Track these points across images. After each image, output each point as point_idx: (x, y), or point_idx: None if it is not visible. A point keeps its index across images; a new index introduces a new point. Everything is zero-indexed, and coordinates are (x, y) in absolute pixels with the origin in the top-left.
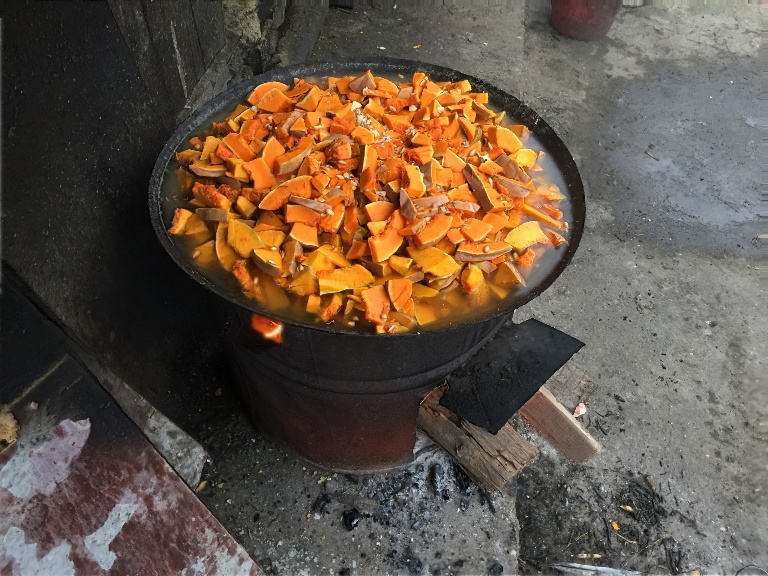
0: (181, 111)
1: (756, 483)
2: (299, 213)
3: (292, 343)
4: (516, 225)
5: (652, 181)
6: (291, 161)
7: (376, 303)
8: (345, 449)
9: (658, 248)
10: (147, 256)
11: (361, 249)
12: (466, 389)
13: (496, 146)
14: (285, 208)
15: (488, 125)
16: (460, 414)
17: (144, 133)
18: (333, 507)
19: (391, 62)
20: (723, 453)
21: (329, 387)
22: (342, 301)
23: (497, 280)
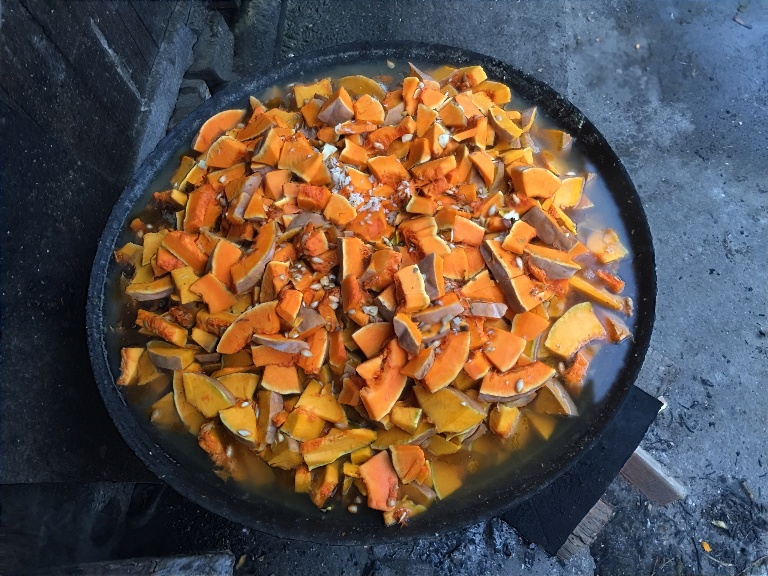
0: (137, 117)
1: None
2: (268, 354)
3: None
4: (560, 312)
5: (743, 62)
6: (249, 275)
7: (380, 482)
8: None
9: (752, 164)
10: None
11: (353, 399)
12: None
13: (524, 197)
14: (250, 348)
15: (512, 154)
16: (510, 523)
17: (80, 207)
18: (383, 574)
19: (375, 46)
20: None
21: None
22: (338, 475)
23: (539, 408)
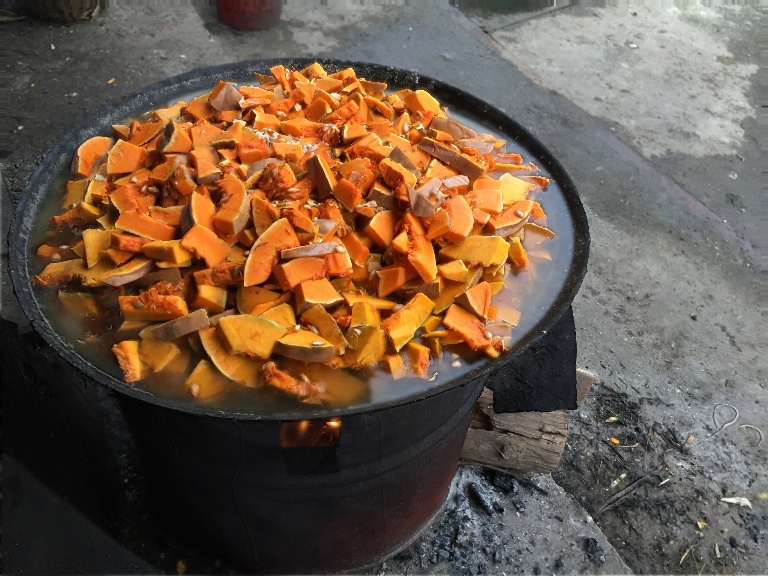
0: None
1: (669, 341)
2: (300, 269)
3: (356, 435)
4: None
5: None
6: (241, 212)
7: (468, 326)
8: (397, 528)
9: None
10: (21, 449)
11: (400, 276)
12: (510, 382)
13: (424, 112)
14: (278, 271)
15: (391, 96)
16: (526, 410)
17: None
18: None
19: (213, 71)
20: (633, 331)
21: (396, 464)
22: (424, 346)
23: (530, 245)
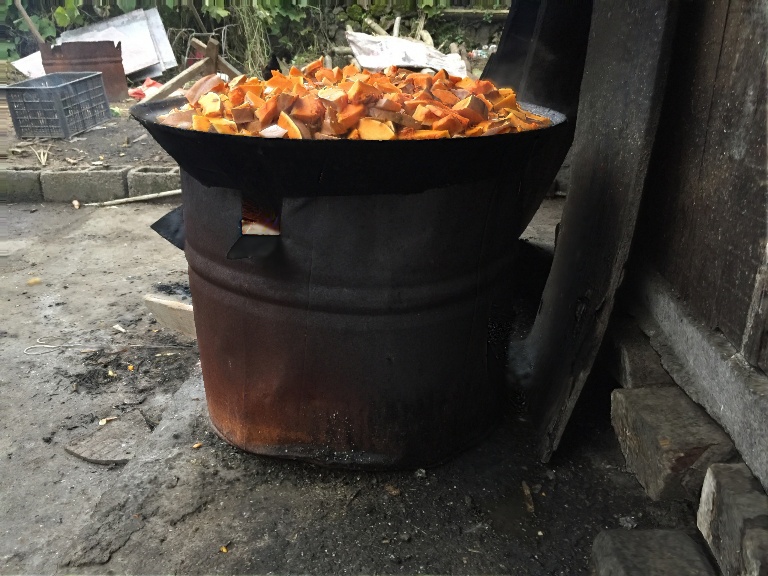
0: None
1: None
2: None
3: None
4: None
5: None
6: None
7: None
8: None
9: None
10: None
11: None
12: None
13: None
14: None
15: None
16: None
17: None
18: None
19: (325, 143)
20: None
21: None
22: None
23: None
